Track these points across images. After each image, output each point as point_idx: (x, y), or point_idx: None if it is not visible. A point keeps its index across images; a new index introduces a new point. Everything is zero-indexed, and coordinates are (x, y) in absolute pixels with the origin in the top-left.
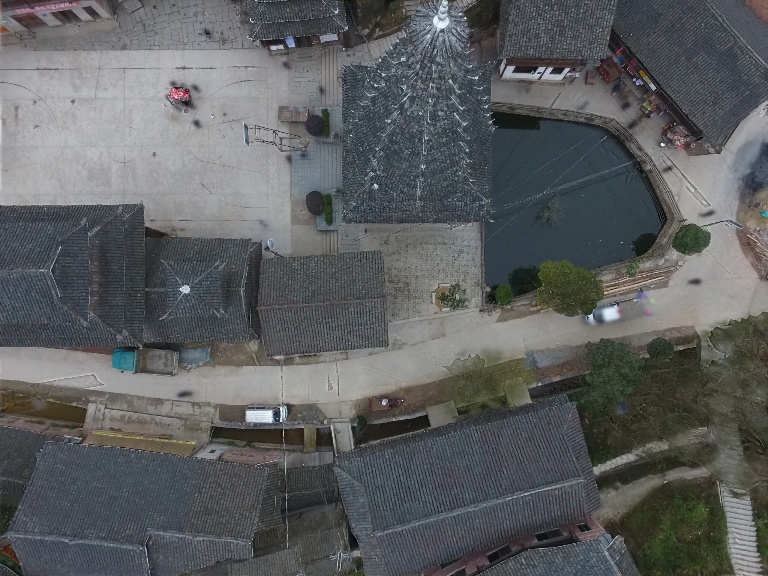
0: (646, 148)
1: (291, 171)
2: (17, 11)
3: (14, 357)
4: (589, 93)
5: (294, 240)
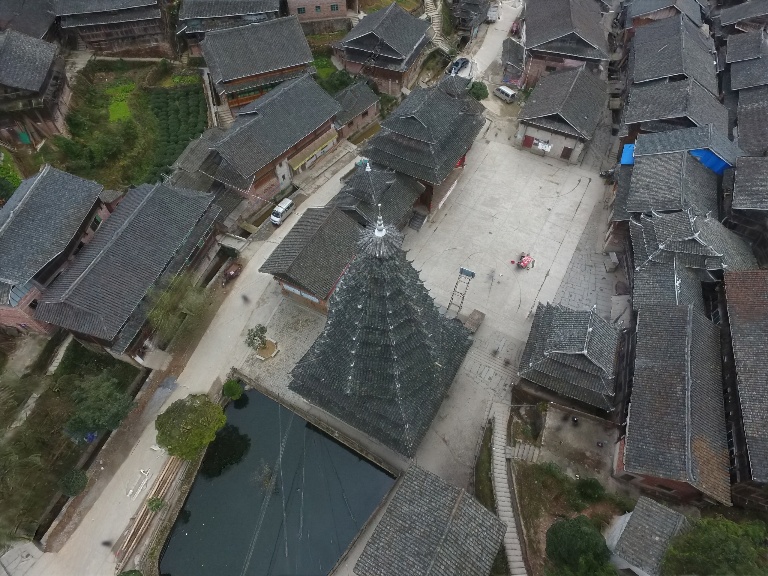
0: None
1: None
2: None
3: None
4: None
5: None
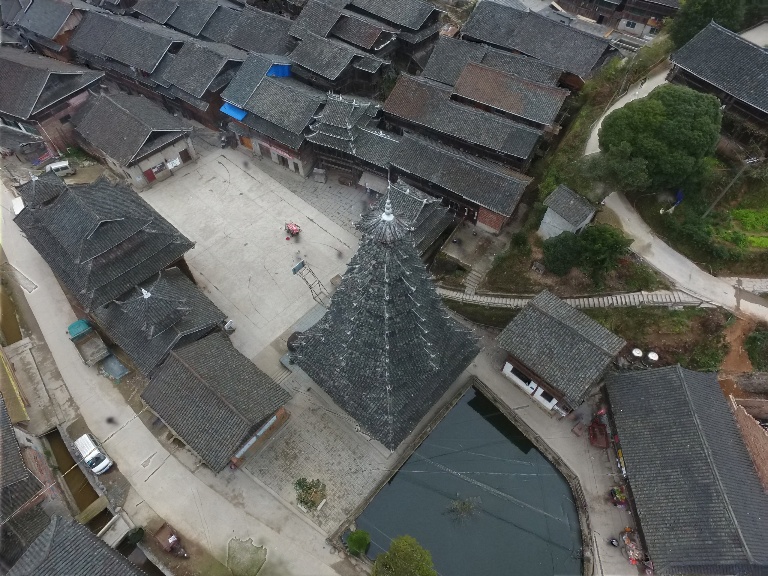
0: (597, 533)
1: (306, 314)
2: (263, 143)
3: (41, 277)
4: (570, 440)
5: (260, 355)
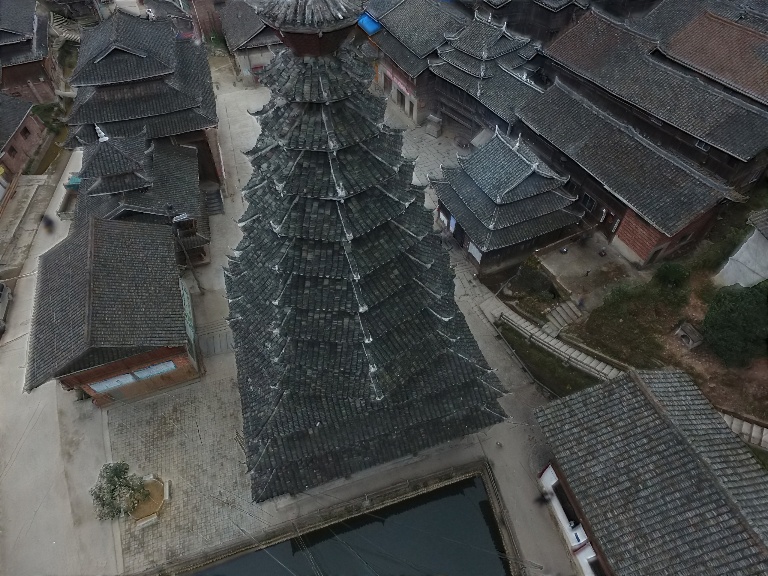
0: None
1: None
2: (388, 72)
3: None
4: None
5: None
